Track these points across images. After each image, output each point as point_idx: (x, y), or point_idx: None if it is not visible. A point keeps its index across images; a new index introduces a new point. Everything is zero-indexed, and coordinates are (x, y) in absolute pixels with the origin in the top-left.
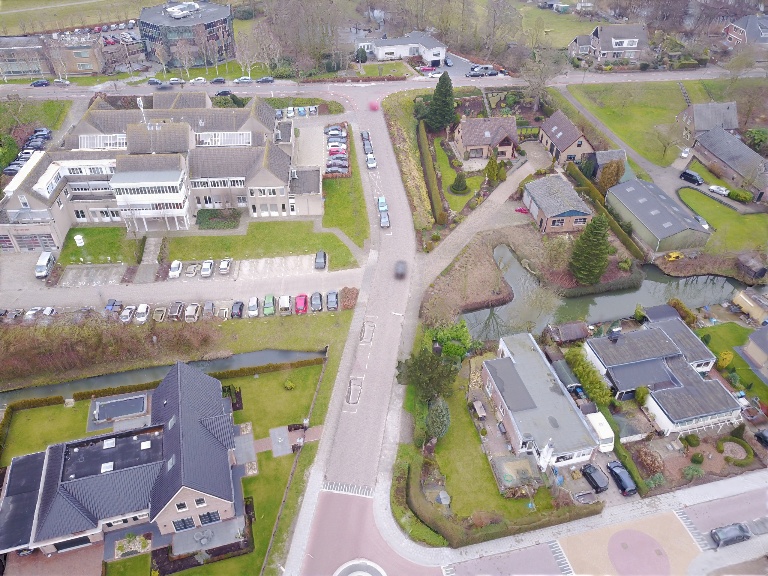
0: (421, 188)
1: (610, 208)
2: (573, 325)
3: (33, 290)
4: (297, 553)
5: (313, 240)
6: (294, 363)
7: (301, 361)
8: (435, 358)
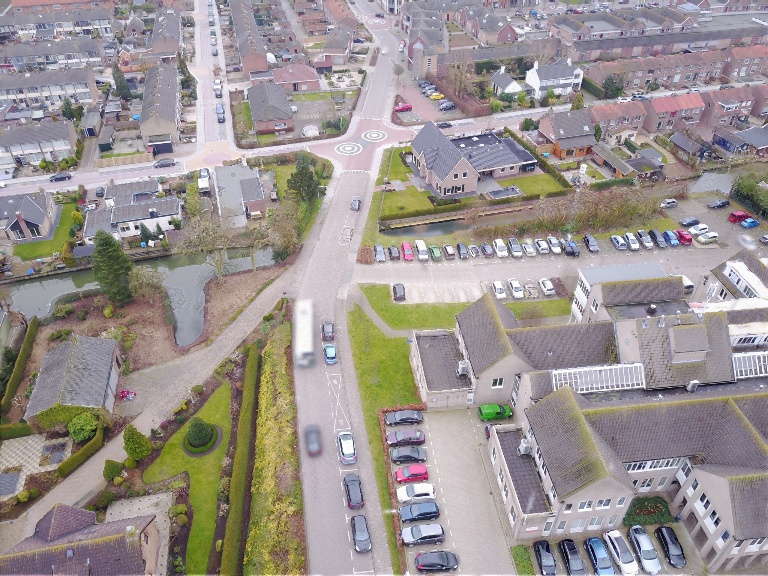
0: (268, 406)
1: (1, 383)
2: (178, 230)
3: (665, 268)
4: (378, 155)
5: (414, 318)
6: (401, 214)
7: (396, 214)
8: (300, 171)
